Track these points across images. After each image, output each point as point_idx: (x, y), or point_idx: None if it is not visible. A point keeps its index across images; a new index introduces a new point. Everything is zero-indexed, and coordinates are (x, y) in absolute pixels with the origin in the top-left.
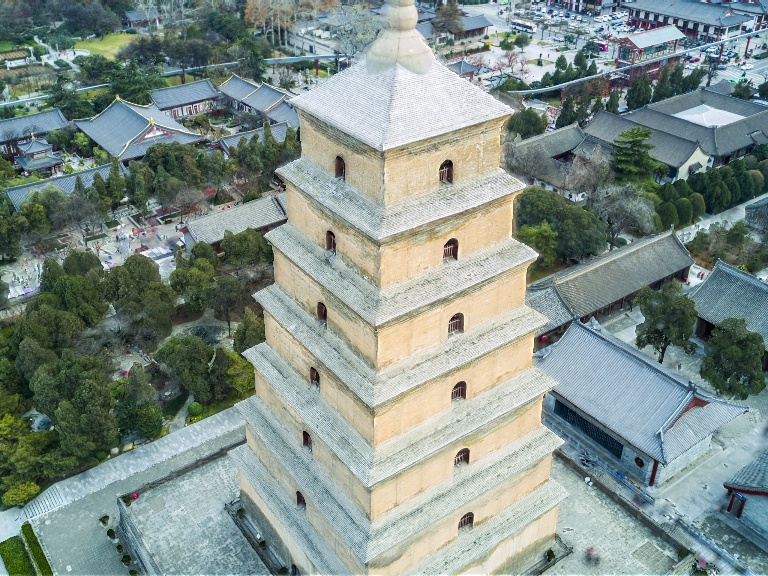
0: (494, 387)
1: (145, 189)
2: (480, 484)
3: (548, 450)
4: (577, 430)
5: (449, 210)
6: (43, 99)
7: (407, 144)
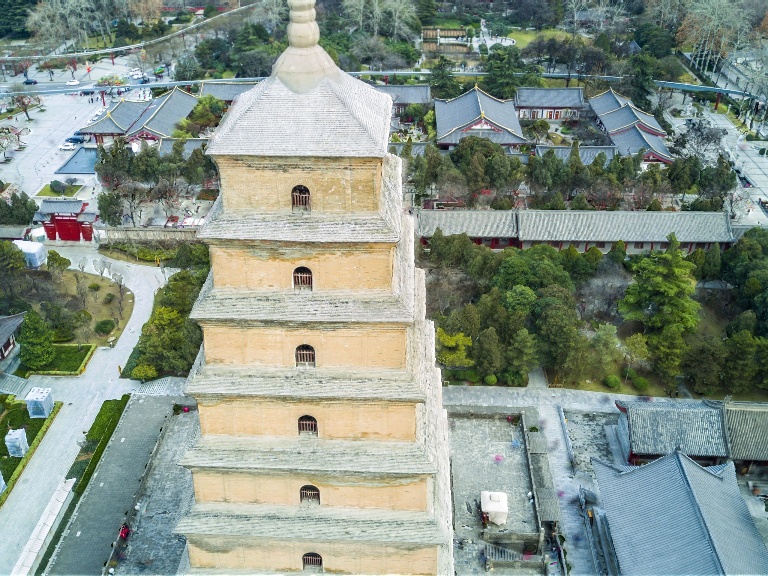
0: (358, 440)
1: (428, 172)
2: (322, 529)
3: (420, 539)
4: (619, 570)
5: (289, 235)
6: (423, 75)
7: (235, 155)
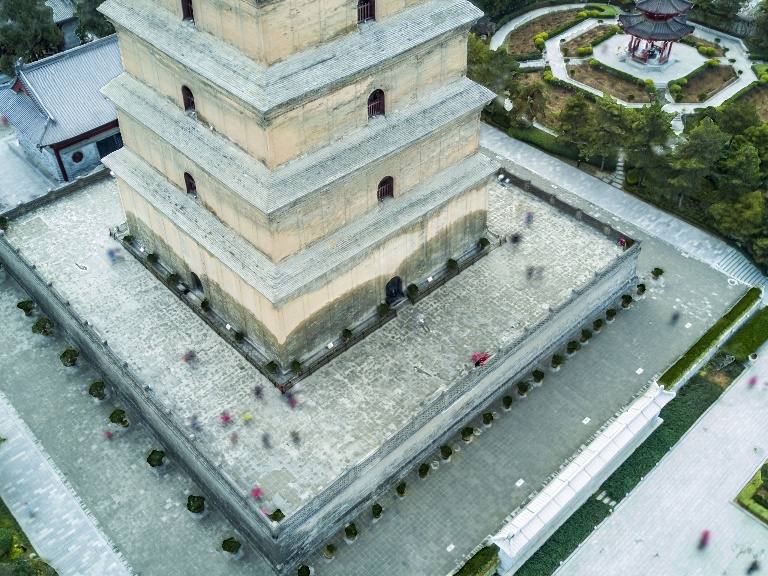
0: None
1: None
2: None
3: None
4: None
5: None
6: None
7: None
